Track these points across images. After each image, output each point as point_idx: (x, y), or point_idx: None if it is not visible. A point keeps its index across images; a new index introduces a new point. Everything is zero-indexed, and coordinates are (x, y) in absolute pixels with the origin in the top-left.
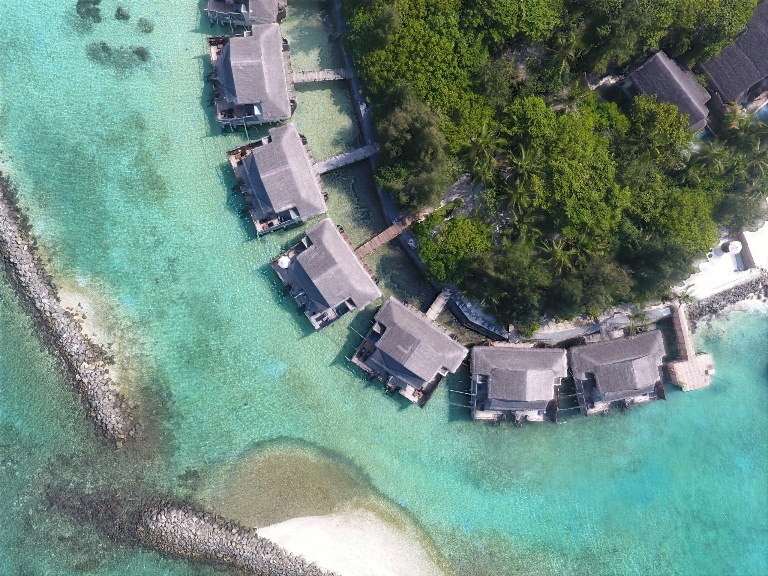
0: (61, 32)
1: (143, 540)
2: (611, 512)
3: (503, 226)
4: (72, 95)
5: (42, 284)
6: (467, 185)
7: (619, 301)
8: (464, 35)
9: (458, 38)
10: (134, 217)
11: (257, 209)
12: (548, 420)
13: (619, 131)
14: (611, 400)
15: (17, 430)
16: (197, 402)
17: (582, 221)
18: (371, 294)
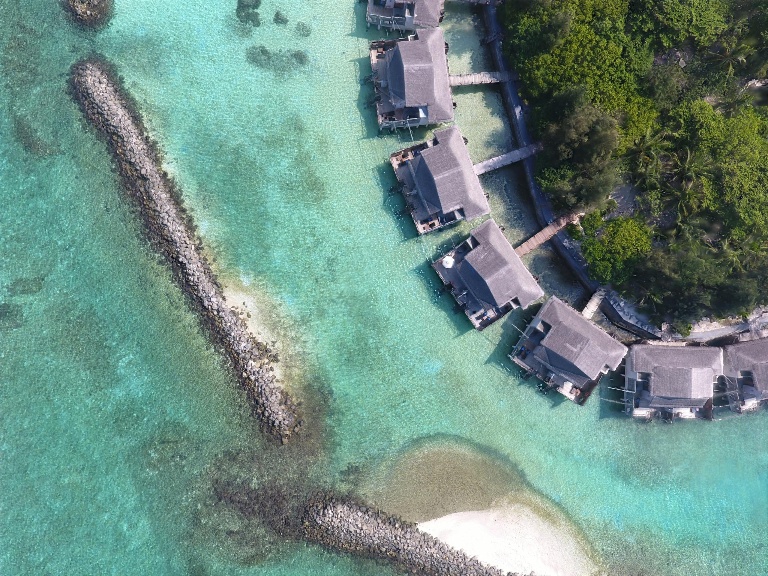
0: (222, 36)
1: (309, 534)
2: (757, 508)
3: (654, 227)
4: (233, 98)
5: (209, 283)
6: (618, 186)
7: None
8: (631, 39)
9: (626, 42)
10: (294, 217)
11: (418, 210)
12: (701, 417)
13: None
14: (766, 397)
15: (184, 426)
16: (357, 399)
17: (754, 222)
18: (535, 293)
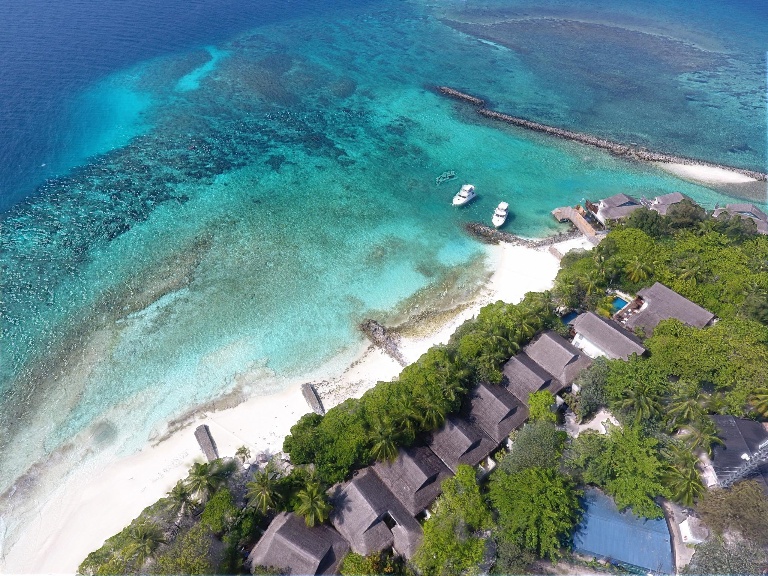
0: None
1: None
2: (584, 179)
3: None
4: None
5: None
6: None
7: None
8: None
9: None
10: None
11: None
12: None
13: None
14: None
15: None
16: None
17: None
18: None
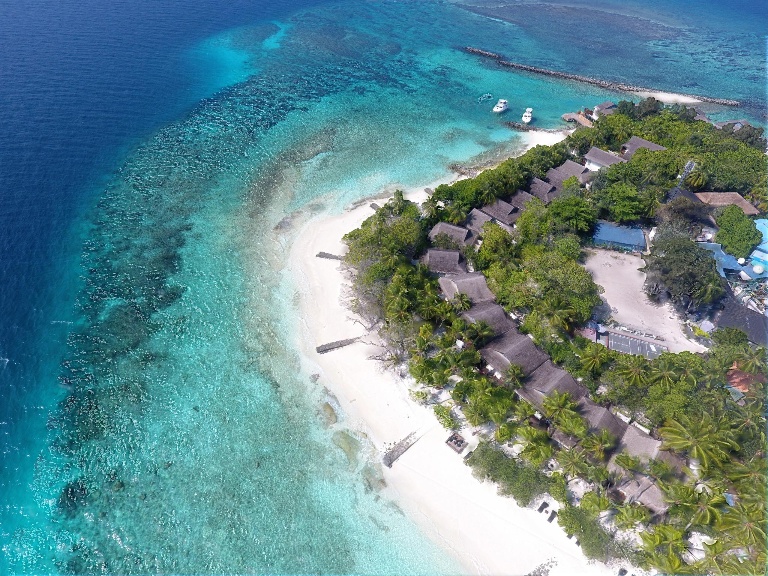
0: None
1: None
2: None
3: None
4: None
5: None
6: None
7: None
8: None
9: None
10: None
11: None
12: None
13: None
14: None
15: None
16: None
17: None
18: (718, 123)
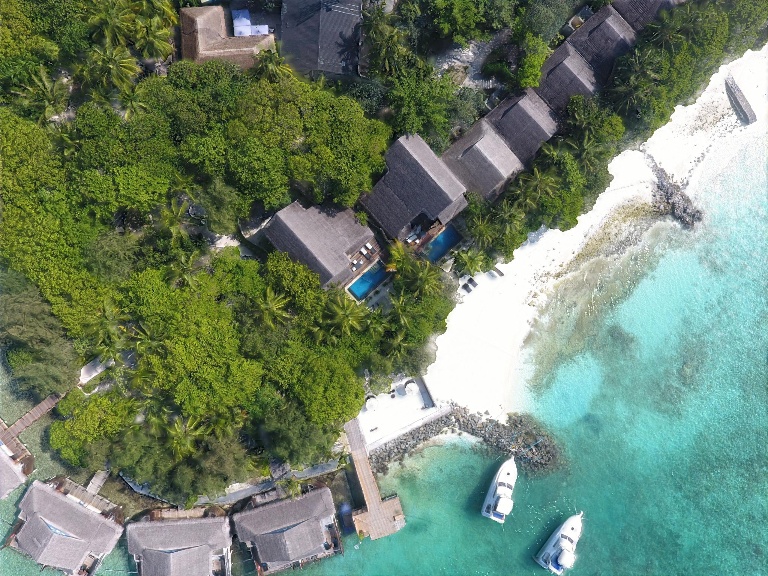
0: None
1: None
2: None
3: None
4: None
5: None
6: None
7: (283, 461)
8: (69, 210)
9: (63, 214)
10: None
11: None
12: None
13: (246, 297)
14: (279, 565)
15: None
16: None
17: None
18: (11, 482)
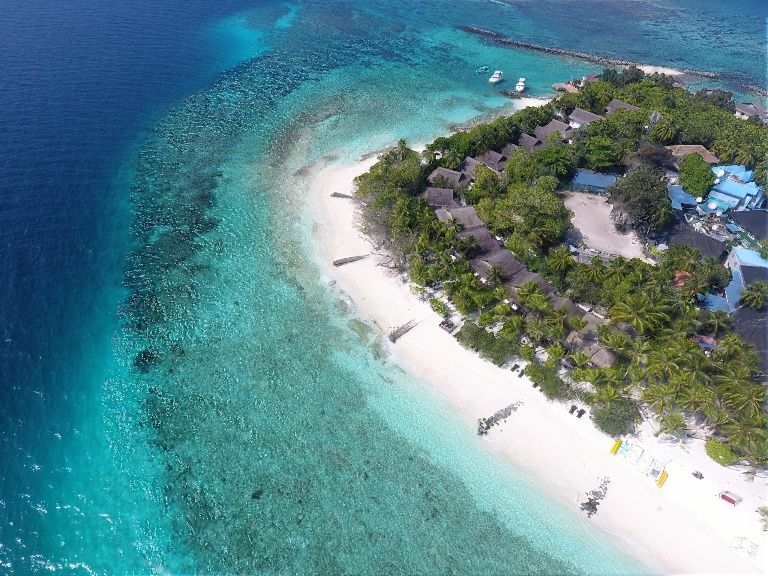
0: None
1: None
2: None
3: None
4: None
5: None
6: None
7: None
8: None
9: None
10: None
11: None
12: None
13: None
14: None
15: None
16: None
17: None
18: None
